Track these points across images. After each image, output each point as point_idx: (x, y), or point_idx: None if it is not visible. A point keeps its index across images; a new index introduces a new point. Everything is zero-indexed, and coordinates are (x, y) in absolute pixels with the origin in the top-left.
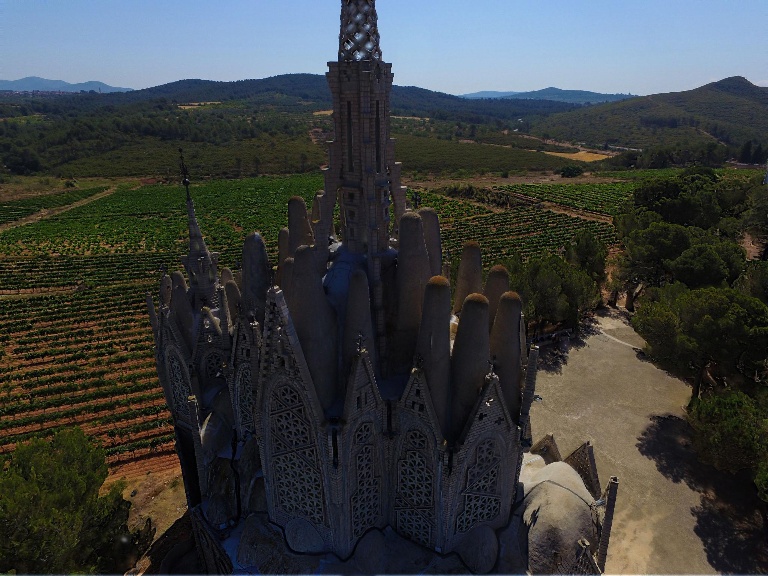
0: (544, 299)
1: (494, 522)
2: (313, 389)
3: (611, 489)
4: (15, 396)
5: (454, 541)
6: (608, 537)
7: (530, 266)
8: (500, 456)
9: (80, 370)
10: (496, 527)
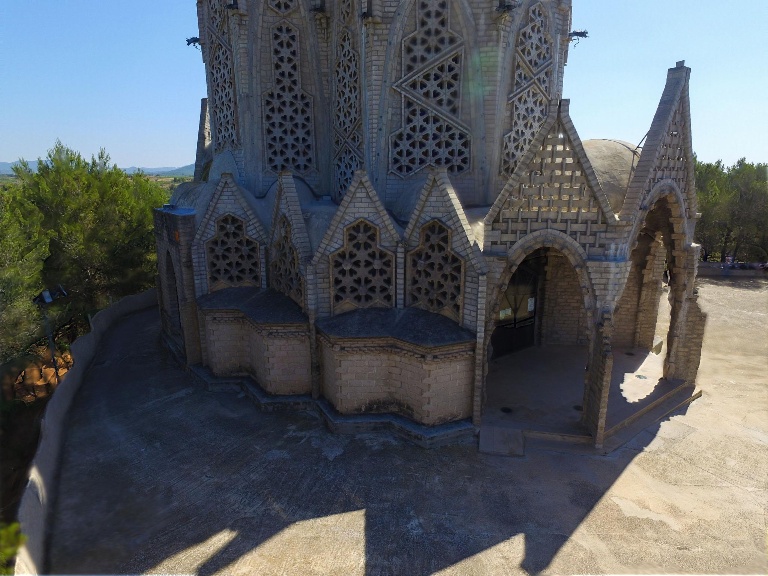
0: (751, 208)
1: (462, 186)
2: None
3: (669, 85)
4: None
5: (388, 189)
6: (648, 165)
7: (733, 170)
8: (463, 38)
9: None
10: (467, 201)
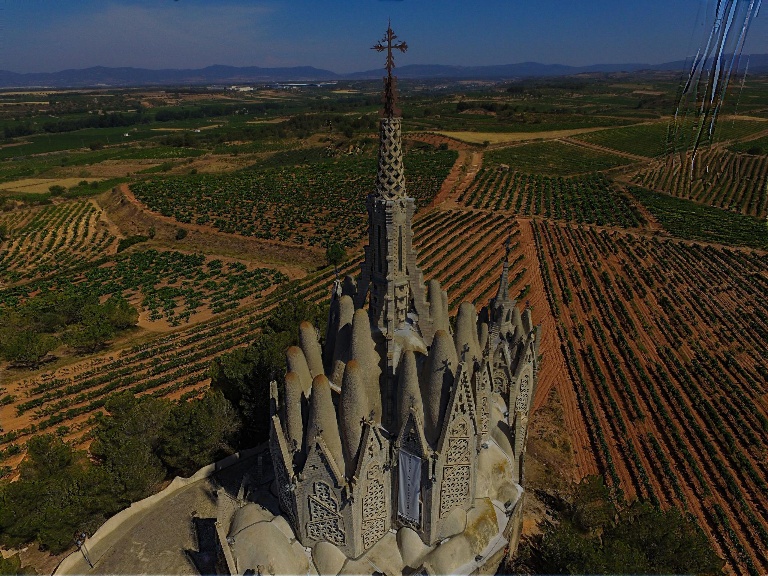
0: None
1: None
2: (327, 331)
3: None
4: (699, 393)
5: None
6: None
7: None
8: None
9: (764, 429)
10: None
